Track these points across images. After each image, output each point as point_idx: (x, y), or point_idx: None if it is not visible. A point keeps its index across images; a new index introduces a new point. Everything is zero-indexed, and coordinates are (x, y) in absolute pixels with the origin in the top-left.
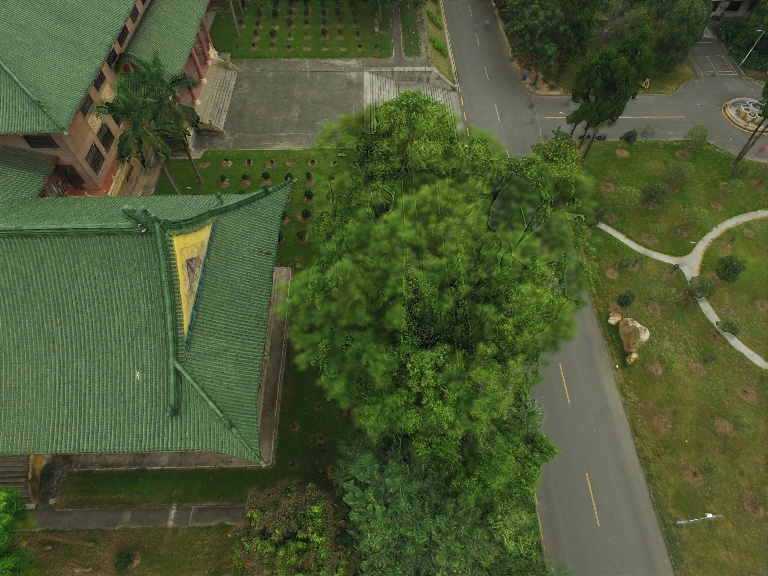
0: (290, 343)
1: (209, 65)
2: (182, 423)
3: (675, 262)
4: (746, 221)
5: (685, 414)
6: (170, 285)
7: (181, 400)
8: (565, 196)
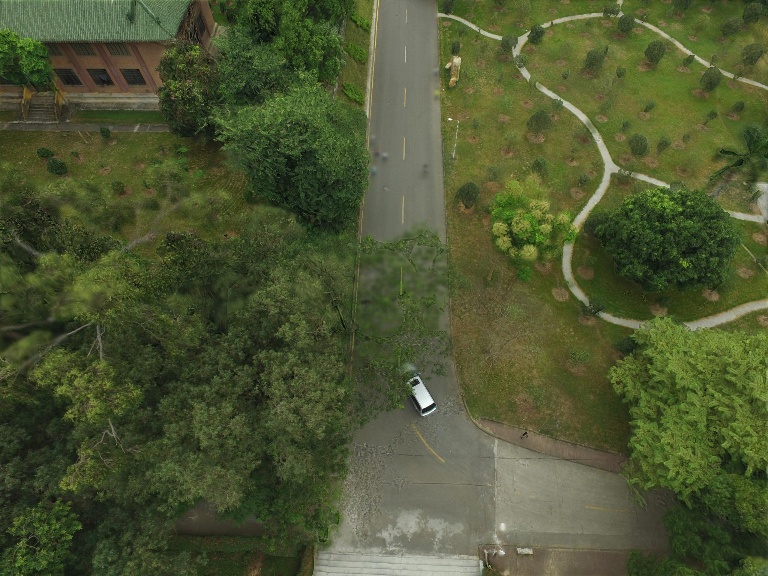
0: None
1: None
2: (136, 27)
3: None
4: (571, 20)
5: (480, 112)
6: None
7: (135, 15)
8: (441, 4)
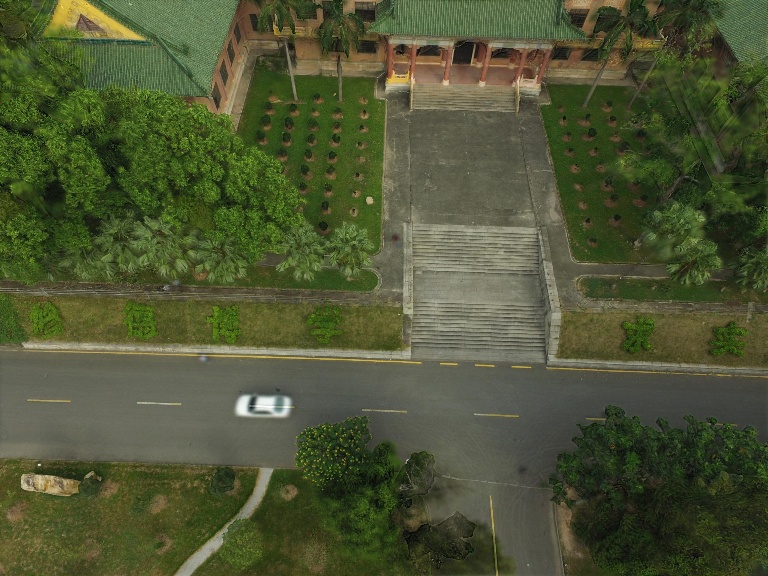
0: None
1: (512, 85)
2: None
3: None
4: None
5: None
6: (49, 2)
7: None
8: None
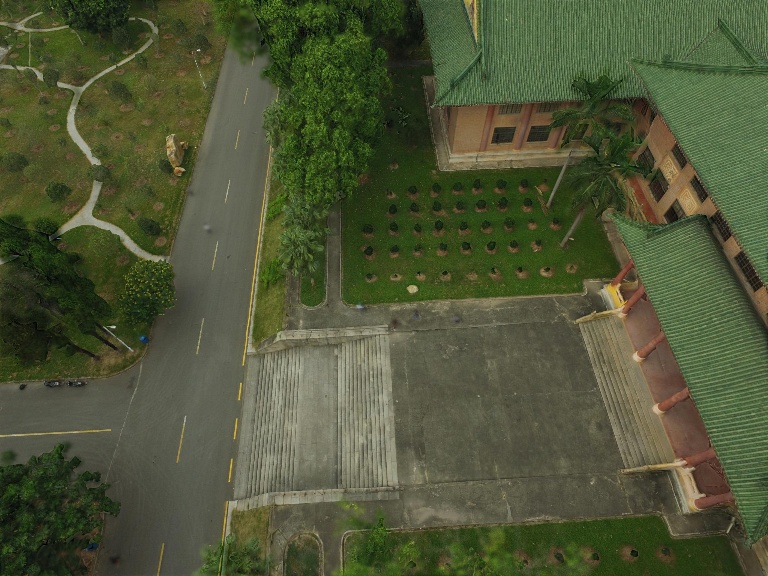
0: (427, 125)
1: None
2: None
3: (92, 220)
4: None
5: None
6: None
7: None
8: None
